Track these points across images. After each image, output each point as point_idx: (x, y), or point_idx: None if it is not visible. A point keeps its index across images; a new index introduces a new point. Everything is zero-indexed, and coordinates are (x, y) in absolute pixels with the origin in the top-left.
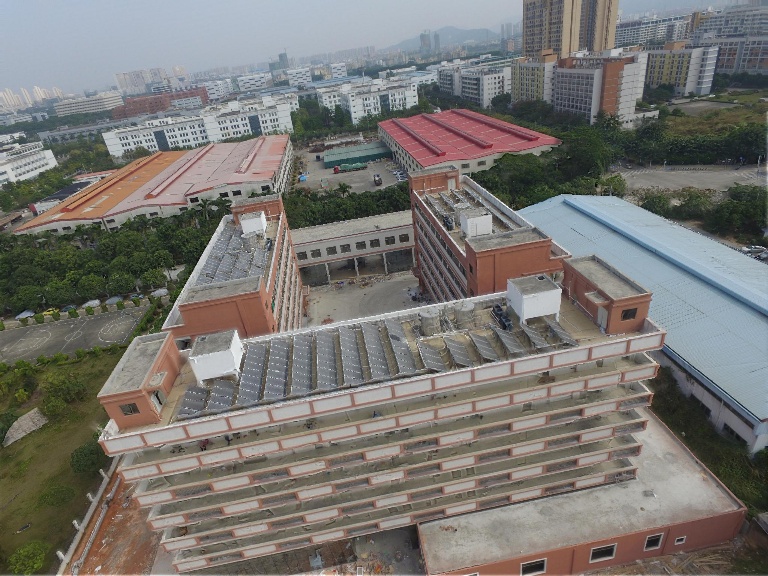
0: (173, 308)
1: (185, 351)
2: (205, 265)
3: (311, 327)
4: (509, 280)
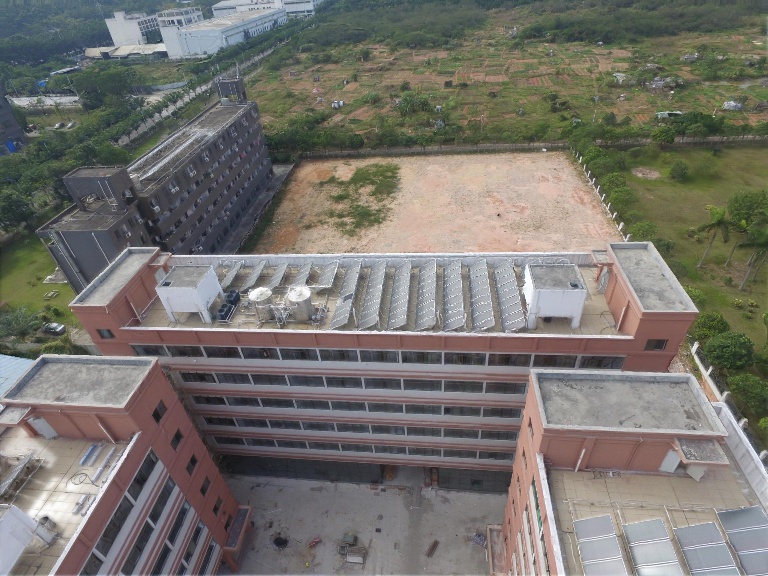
0: None
1: (622, 334)
2: None
3: (442, 333)
4: (197, 287)
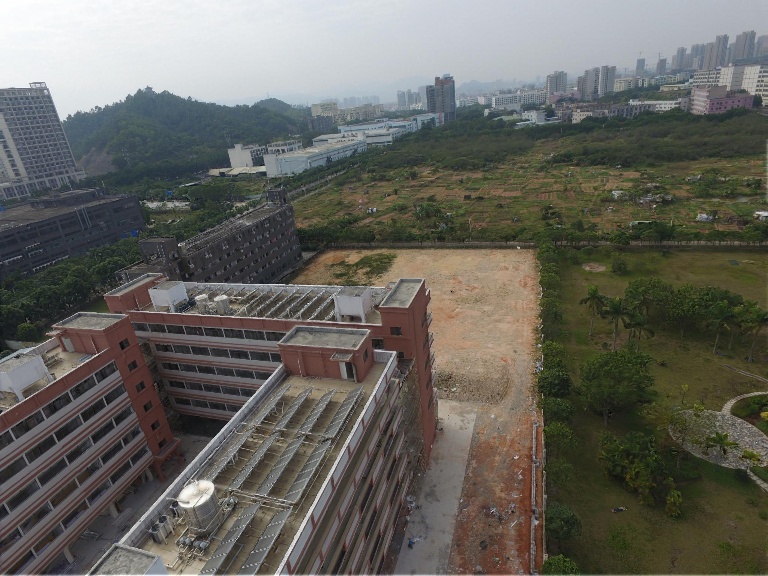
0: (382, 376)
1: None
2: (316, 464)
3: (283, 319)
4: None
